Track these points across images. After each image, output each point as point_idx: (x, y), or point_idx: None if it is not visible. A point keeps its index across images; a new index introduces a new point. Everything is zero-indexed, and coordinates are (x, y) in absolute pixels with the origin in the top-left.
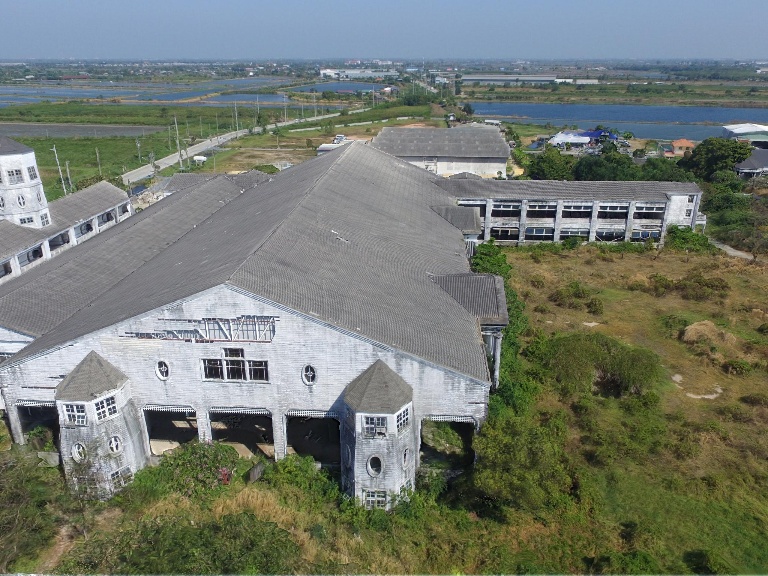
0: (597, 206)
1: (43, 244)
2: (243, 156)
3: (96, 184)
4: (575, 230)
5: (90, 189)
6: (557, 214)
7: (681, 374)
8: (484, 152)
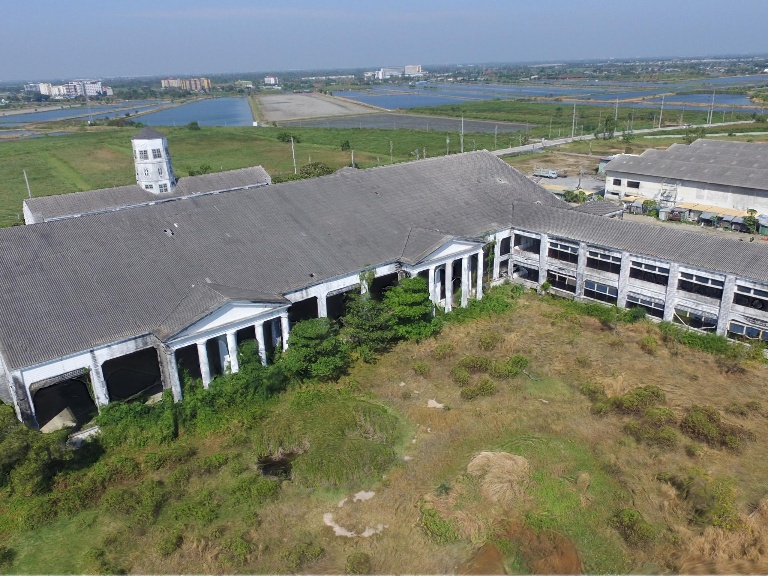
0: (675, 271)
1: None
2: (541, 159)
3: (249, 168)
4: (647, 298)
5: (238, 171)
6: (621, 270)
7: (375, 494)
8: (753, 180)
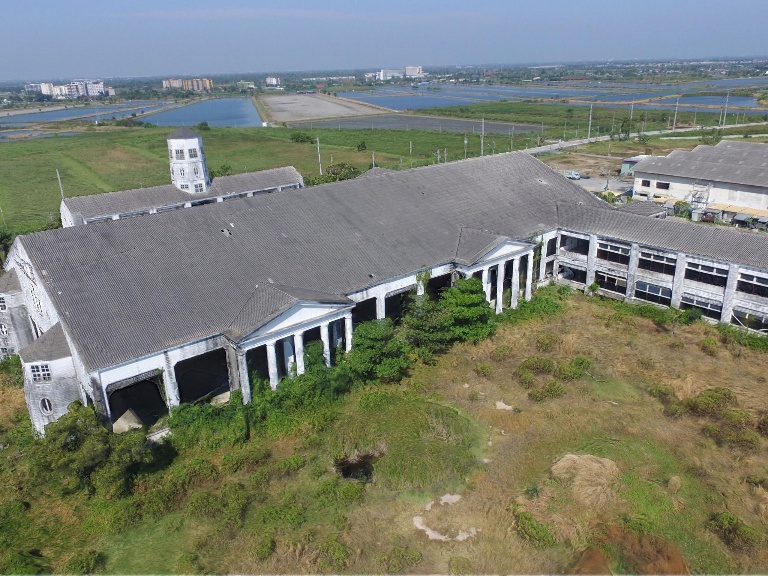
0: (735, 272)
1: (186, 205)
2: (560, 161)
3: (281, 168)
4: (702, 300)
5: (271, 171)
6: (676, 271)
7: (462, 497)
8: None
